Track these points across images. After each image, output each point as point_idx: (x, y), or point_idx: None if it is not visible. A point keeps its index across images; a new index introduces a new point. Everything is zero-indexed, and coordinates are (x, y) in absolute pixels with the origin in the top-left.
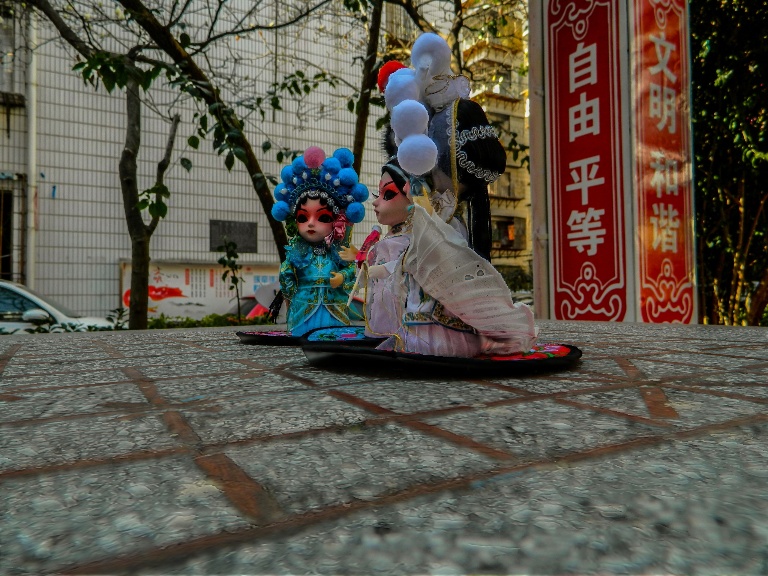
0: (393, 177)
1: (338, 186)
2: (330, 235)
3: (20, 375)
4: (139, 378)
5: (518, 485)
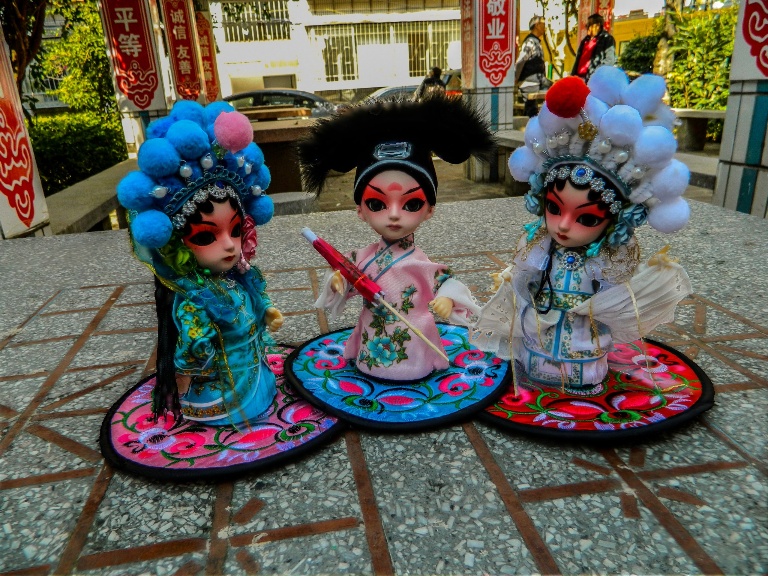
0: (420, 181)
1: None
2: (242, 254)
3: None
4: None
5: None
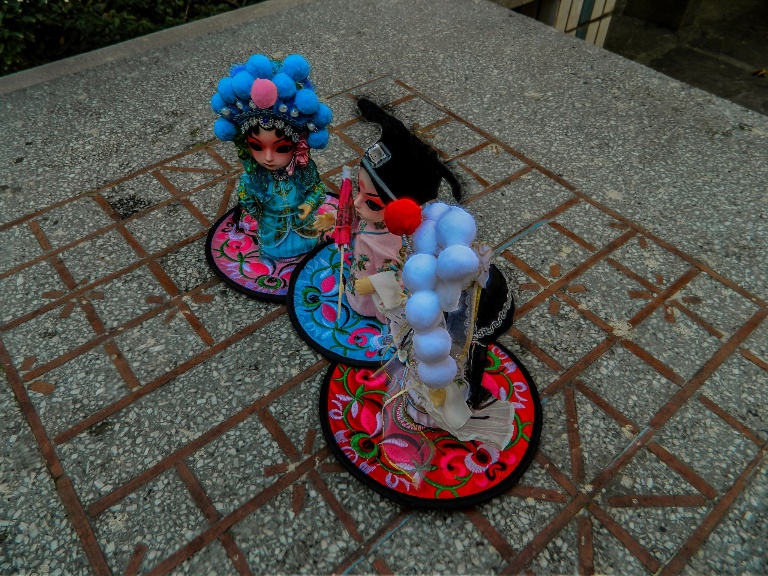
0: (379, 192)
1: (296, 117)
2: (291, 163)
3: (101, 506)
4: (213, 517)
5: None
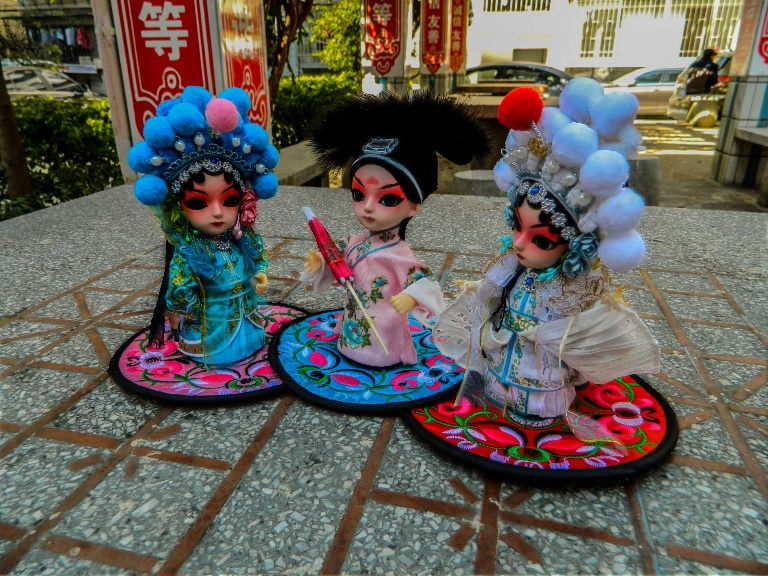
0: (398, 179)
1: (248, 154)
2: (238, 222)
3: None
4: None
5: None
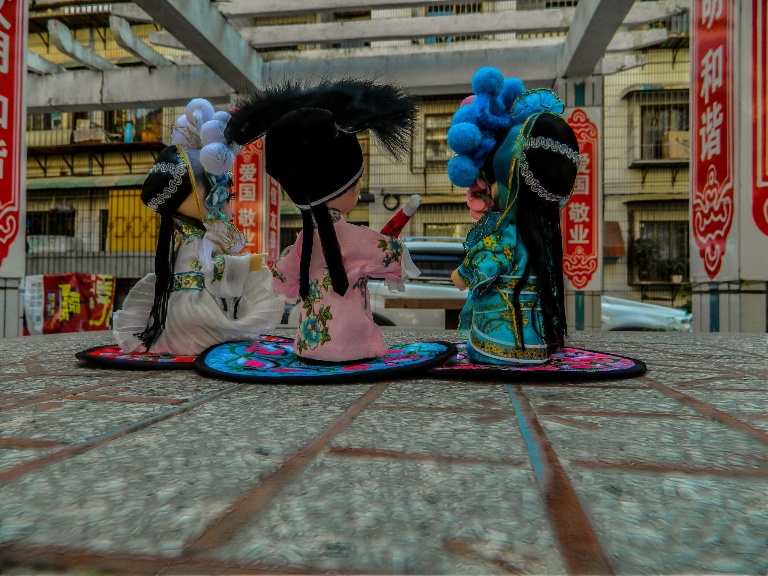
0: None
1: None
2: None
3: None
4: None
5: (81, 347)
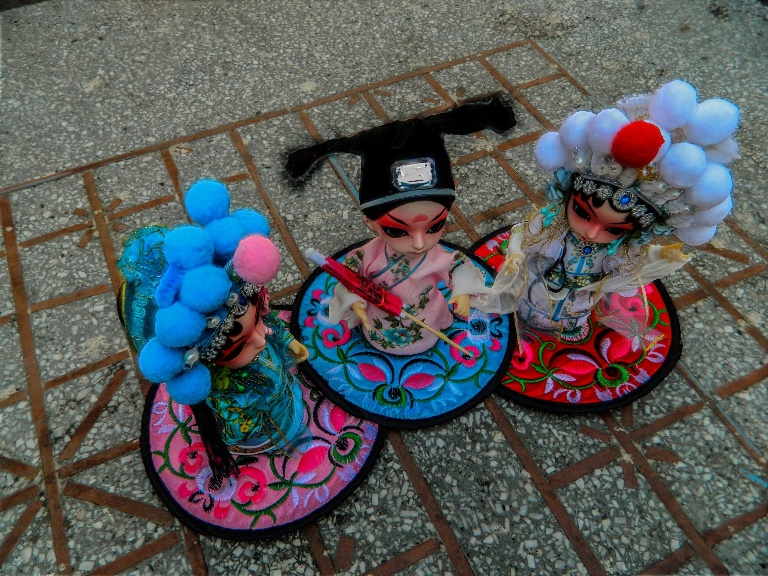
0: (446, 204)
1: None
2: None
3: None
4: (689, 553)
5: None
